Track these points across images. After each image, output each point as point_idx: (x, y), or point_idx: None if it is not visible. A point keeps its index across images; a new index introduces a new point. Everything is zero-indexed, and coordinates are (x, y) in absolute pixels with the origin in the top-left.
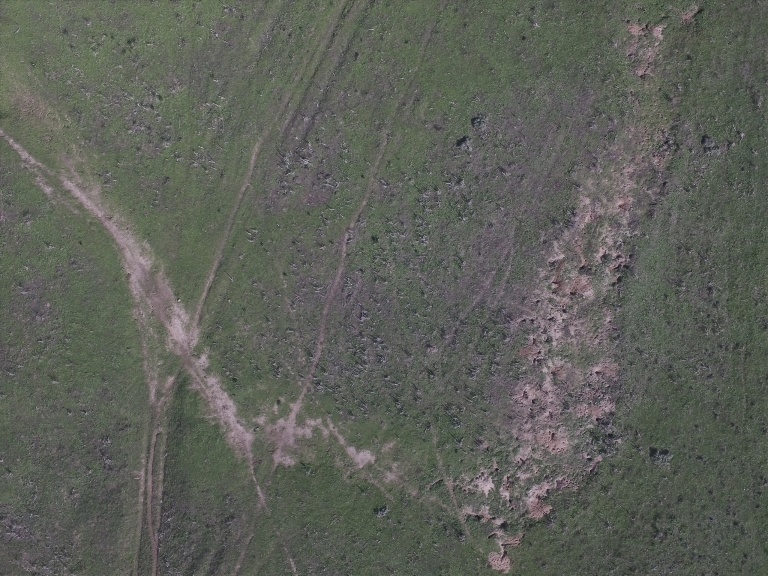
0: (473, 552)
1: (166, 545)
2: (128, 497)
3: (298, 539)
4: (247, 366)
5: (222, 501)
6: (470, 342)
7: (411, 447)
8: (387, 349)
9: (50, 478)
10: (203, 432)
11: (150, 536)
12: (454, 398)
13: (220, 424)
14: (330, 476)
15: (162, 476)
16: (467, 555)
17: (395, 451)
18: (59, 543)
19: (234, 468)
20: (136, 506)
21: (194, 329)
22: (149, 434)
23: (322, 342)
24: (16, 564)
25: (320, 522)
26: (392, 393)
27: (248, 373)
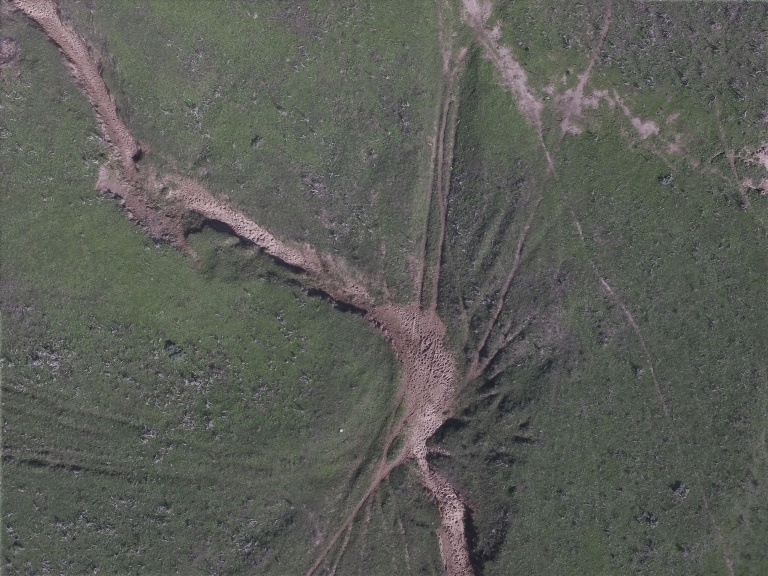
0: (754, 222)
1: (456, 208)
2: (423, 160)
3: (585, 203)
4: (538, 37)
5: (514, 164)
6: (753, 20)
7: (695, 119)
8: (672, 25)
9: (351, 139)
10: (497, 97)
11: (439, 201)
12: (737, 73)
13: (512, 92)
14: (616, 144)
15: (453, 144)
16: (748, 225)
17: (679, 123)
18: (357, 202)
19: (525, 133)
20: (428, 171)
21: (487, 3)
22: (442, 103)
23: (609, 17)
24: (317, 220)
25: (606, 187)
26: (677, 67)
27: (540, 44)
